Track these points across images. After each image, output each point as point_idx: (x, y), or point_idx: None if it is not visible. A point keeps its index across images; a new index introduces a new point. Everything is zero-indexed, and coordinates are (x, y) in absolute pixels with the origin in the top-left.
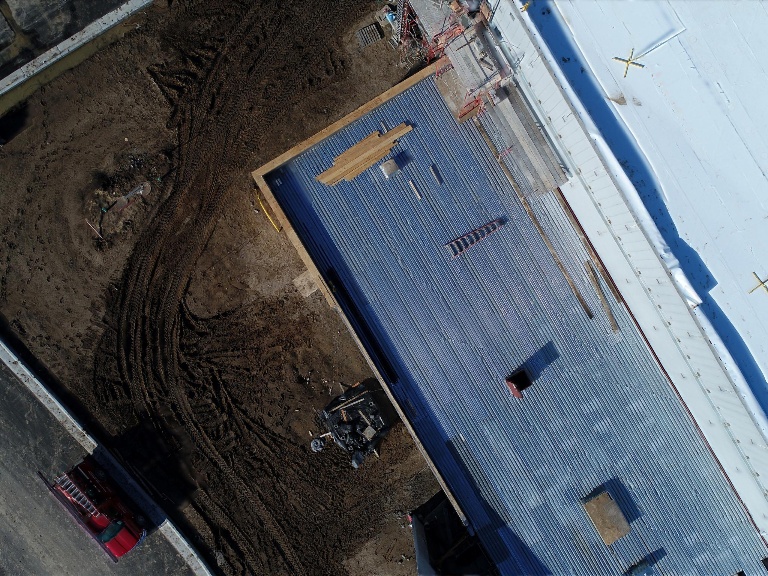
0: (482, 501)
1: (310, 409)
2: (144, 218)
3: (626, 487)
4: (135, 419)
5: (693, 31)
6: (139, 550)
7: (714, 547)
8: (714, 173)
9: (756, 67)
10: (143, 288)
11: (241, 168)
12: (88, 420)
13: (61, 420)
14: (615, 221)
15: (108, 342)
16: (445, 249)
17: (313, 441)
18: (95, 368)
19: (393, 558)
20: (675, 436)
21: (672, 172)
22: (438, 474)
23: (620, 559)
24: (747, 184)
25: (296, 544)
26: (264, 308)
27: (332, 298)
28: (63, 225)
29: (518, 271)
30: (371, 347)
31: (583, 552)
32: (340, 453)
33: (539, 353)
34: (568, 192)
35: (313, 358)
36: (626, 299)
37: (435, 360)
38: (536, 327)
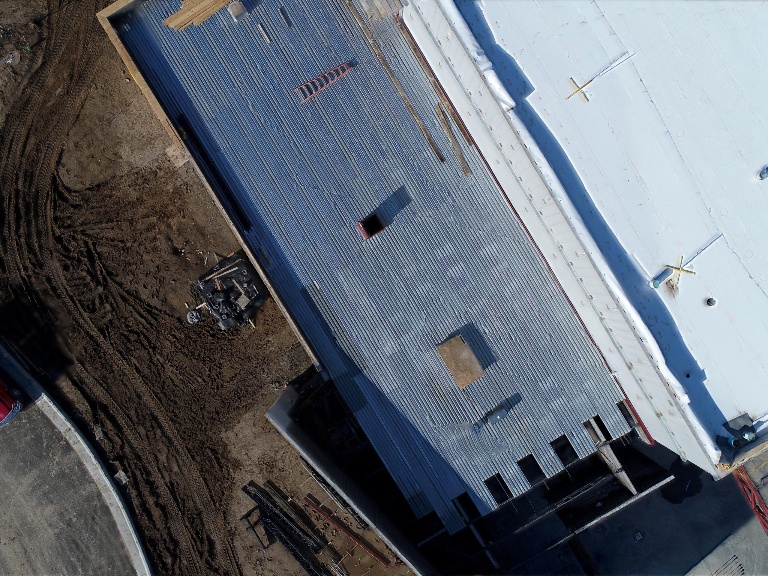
0: (338, 349)
1: (186, 281)
2: (14, 89)
3: (481, 332)
4: (10, 294)
5: None
6: (17, 425)
7: (569, 391)
8: None
9: None
10: (16, 161)
11: None
12: None
13: None
14: (441, 37)
15: None
16: (295, 93)
17: (189, 313)
18: None
19: (271, 429)
20: (529, 280)
21: None
22: (290, 319)
23: (476, 405)
24: None
25: (174, 417)
26: (138, 179)
27: (180, 142)
28: None
29: (369, 115)
30: (224, 194)
31: (439, 399)
32: (216, 324)
33: (392, 198)
34: (413, 29)
35: (188, 229)
36: (476, 141)
37: (288, 207)
38: (388, 172)
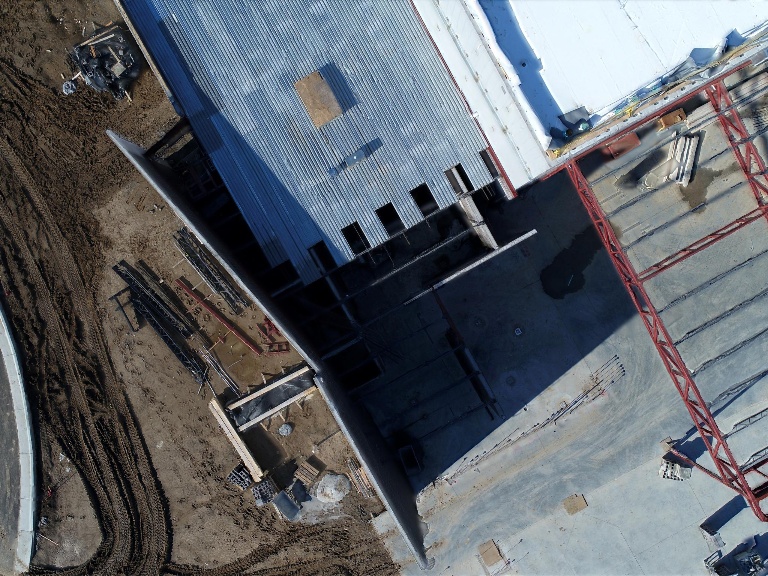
0: (195, 86)
1: (62, 50)
2: None
3: (342, 73)
4: None
5: None
6: None
7: (431, 138)
8: None
9: None
10: None
11: None
12: None
13: None
14: None
15: None
16: None
17: (64, 83)
18: None
19: (145, 208)
20: (393, 20)
21: None
22: (143, 46)
23: (335, 149)
24: None
25: (45, 191)
26: None
27: None
28: None
29: None
30: None
31: (298, 142)
32: (92, 96)
33: None
34: None
35: None
36: None
37: None
38: None
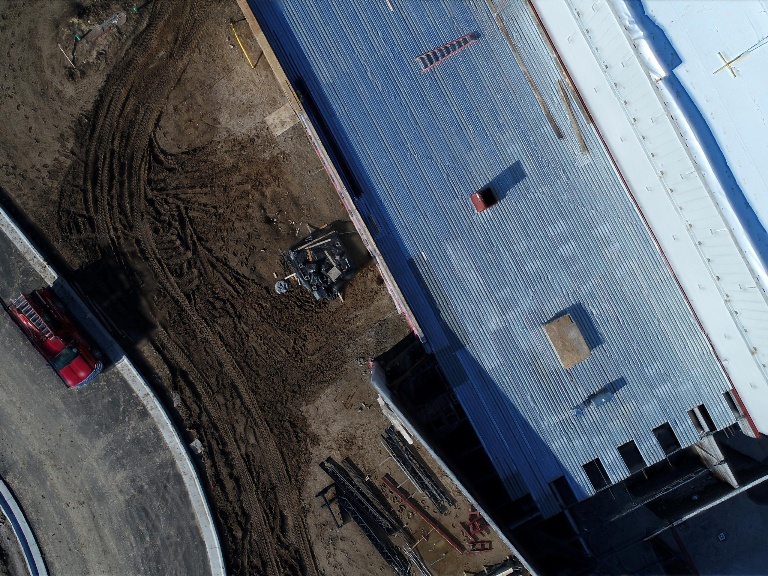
0: (441, 322)
1: (276, 250)
2: (118, 49)
3: (588, 313)
4: (98, 253)
5: None
6: (95, 387)
7: (675, 378)
8: None
9: None
10: (113, 121)
11: (218, 3)
12: (50, 252)
13: (23, 250)
14: (583, 8)
15: (75, 174)
16: (415, 63)
17: (277, 283)
18: (60, 200)
19: (353, 406)
20: (640, 263)
21: None
22: (397, 288)
23: (579, 387)
24: None
25: (255, 388)
26: (234, 145)
27: (298, 103)
28: (36, 54)
29: (488, 88)
30: (336, 160)
31: (542, 378)
32: (304, 296)
33: (505, 172)
34: (541, 4)
35: (281, 198)
36: (595, 119)
37: (400, 175)
38: (504, 146)
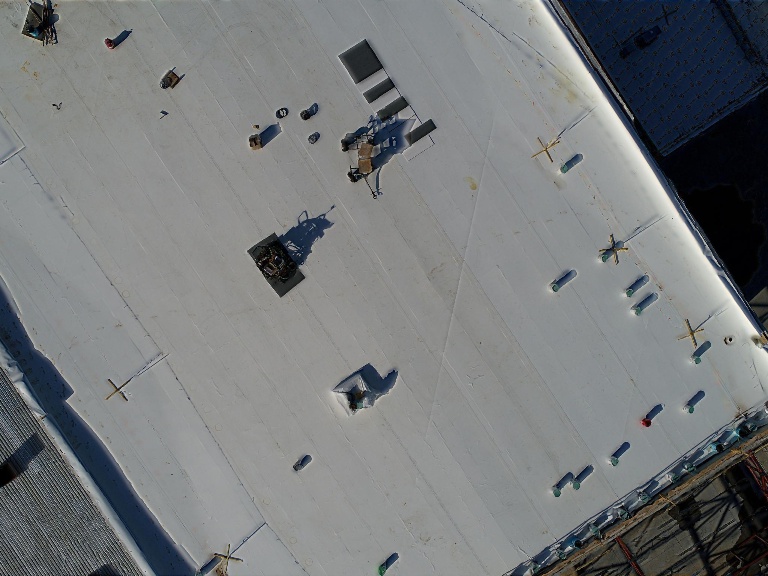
0: None
1: None
2: None
3: (119, 572)
4: None
5: (32, 148)
6: None
7: None
8: (65, 285)
9: (96, 181)
10: None
11: None
12: None
13: None
14: None
15: None
16: None
17: None
18: None
19: None
20: None
21: (23, 286)
22: None
23: None
24: (97, 294)
25: None
26: None
27: None
28: None
29: None
30: None
31: None
32: None
33: (25, 445)
34: None
35: None
36: None
37: None
38: (20, 420)
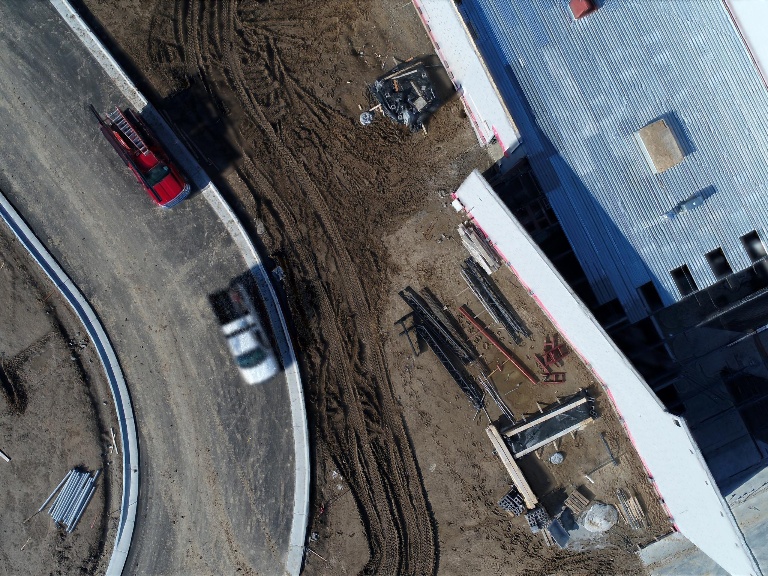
0: (536, 128)
1: (362, 82)
2: None
3: (680, 122)
4: (187, 82)
5: None
6: (180, 213)
7: (763, 188)
8: None
9: None
10: None
11: None
12: (140, 80)
13: (113, 77)
14: None
15: (166, 4)
16: None
17: (362, 114)
18: (151, 29)
19: (433, 237)
20: (732, 73)
21: None
22: (496, 89)
23: (669, 194)
24: None
25: (337, 217)
26: None
27: None
28: None
29: None
30: None
31: (633, 185)
32: (388, 127)
33: None
34: None
35: (368, 31)
36: None
37: None
38: None
